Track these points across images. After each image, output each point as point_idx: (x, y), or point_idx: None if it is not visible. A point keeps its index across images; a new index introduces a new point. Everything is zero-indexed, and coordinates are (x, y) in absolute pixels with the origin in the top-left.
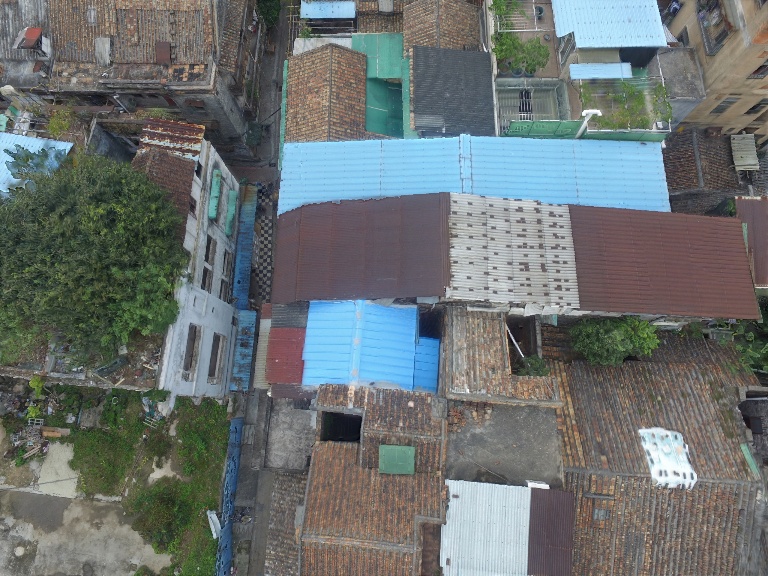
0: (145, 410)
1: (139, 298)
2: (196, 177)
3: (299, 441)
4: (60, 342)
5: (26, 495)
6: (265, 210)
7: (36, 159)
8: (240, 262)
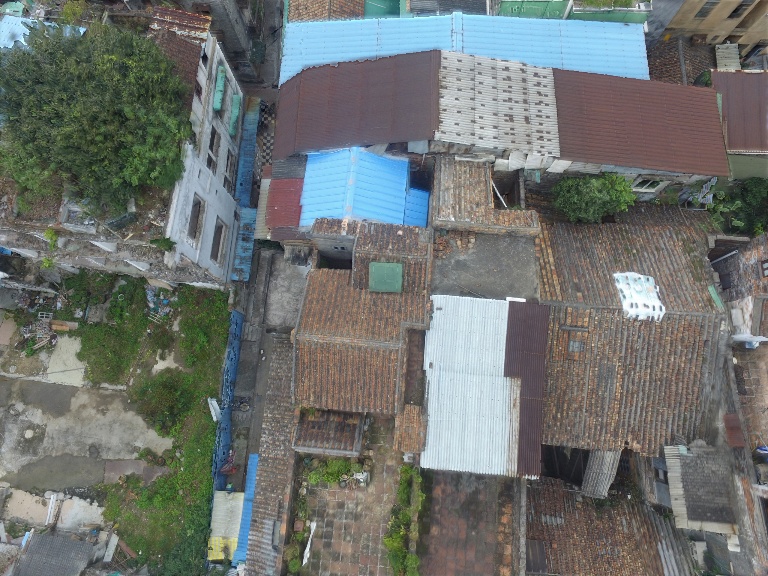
0: (150, 306)
1: (148, 141)
2: (202, 65)
3: (296, 302)
4: (73, 197)
5: (35, 383)
6: (267, 127)
7: (52, 32)
8: (243, 166)
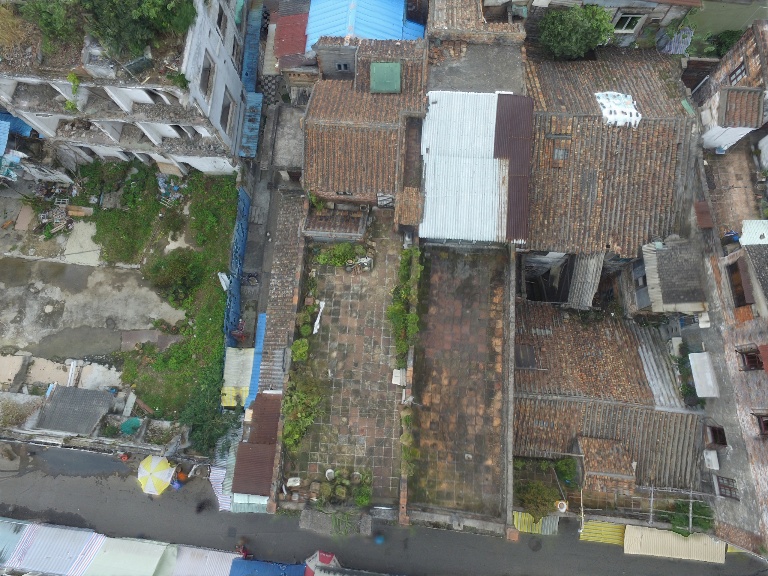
0: (161, 191)
1: None
2: None
3: None
4: (94, 42)
5: (54, 264)
6: None
7: None
8: (248, 58)
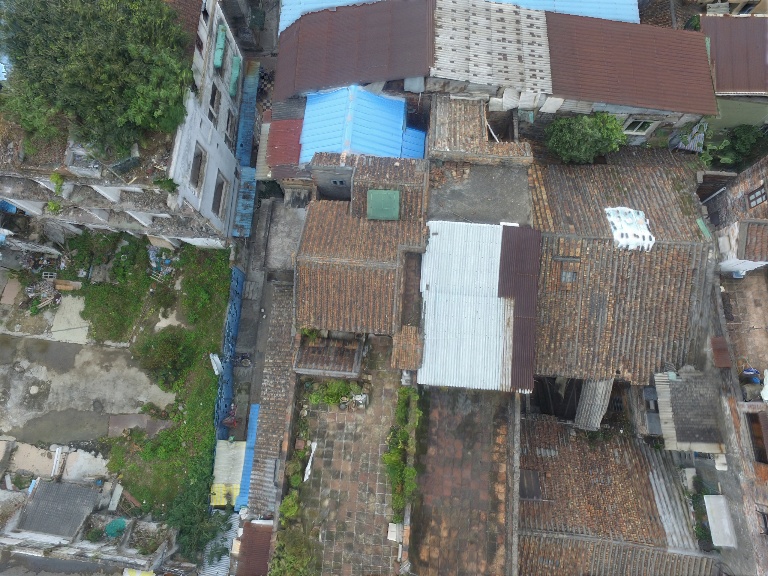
0: (152, 265)
1: (152, 80)
2: (203, 20)
3: None
4: (78, 141)
5: (40, 342)
6: (267, 94)
7: None
8: (243, 128)
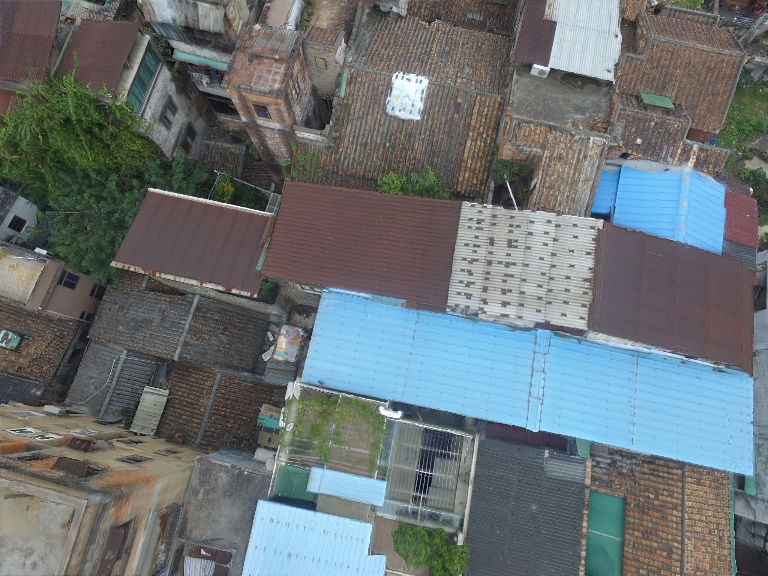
0: None
1: None
2: None
3: None
4: None
5: None
6: None
7: None
8: None
